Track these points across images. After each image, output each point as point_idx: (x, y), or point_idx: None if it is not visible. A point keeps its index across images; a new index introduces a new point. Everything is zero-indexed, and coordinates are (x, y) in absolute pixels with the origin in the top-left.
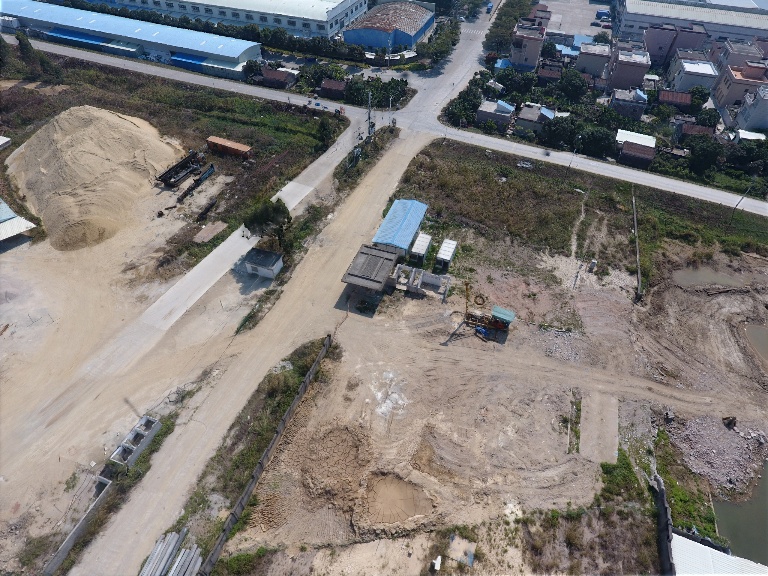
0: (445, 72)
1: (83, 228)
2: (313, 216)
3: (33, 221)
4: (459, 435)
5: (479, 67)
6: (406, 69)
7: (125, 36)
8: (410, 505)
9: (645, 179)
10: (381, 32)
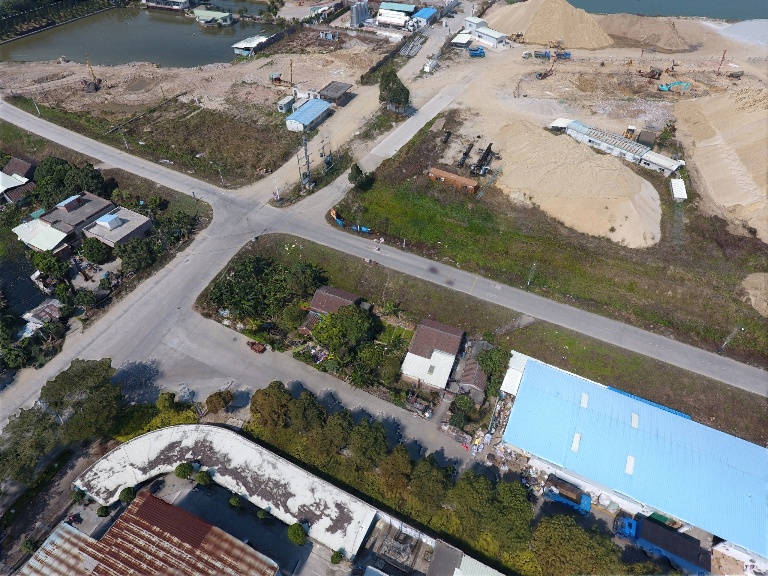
0: None
1: None
2: None
3: None
4: None
5: None
6: None
7: None
8: None
9: (74, 139)
10: None
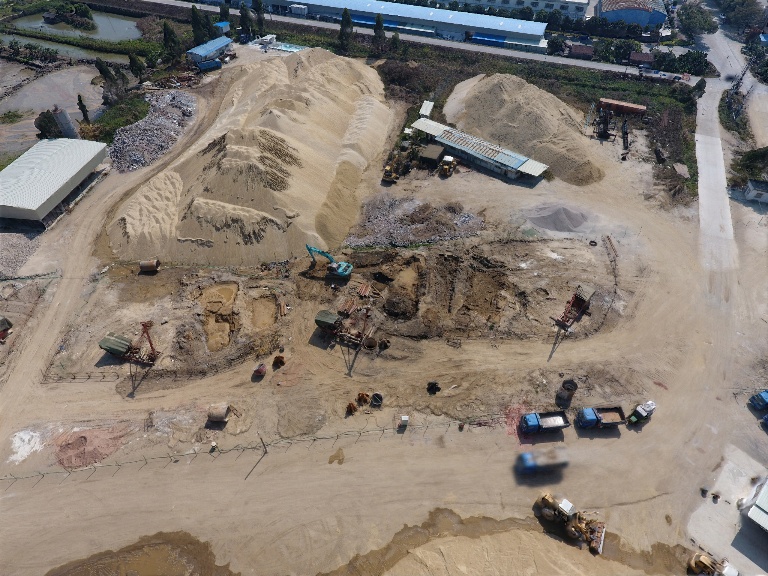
0: (710, 46)
1: (589, 167)
2: None
3: None
4: None
5: (734, 42)
6: (675, 44)
7: (423, 19)
8: None
9: None
10: (643, 12)
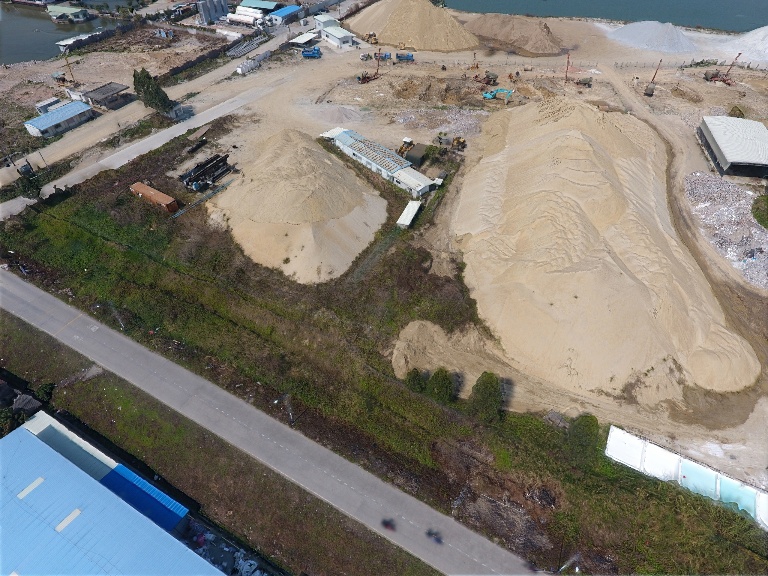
0: None
1: None
2: (118, 136)
3: None
4: (124, 64)
5: None
6: None
7: None
8: (156, 55)
9: None
10: None
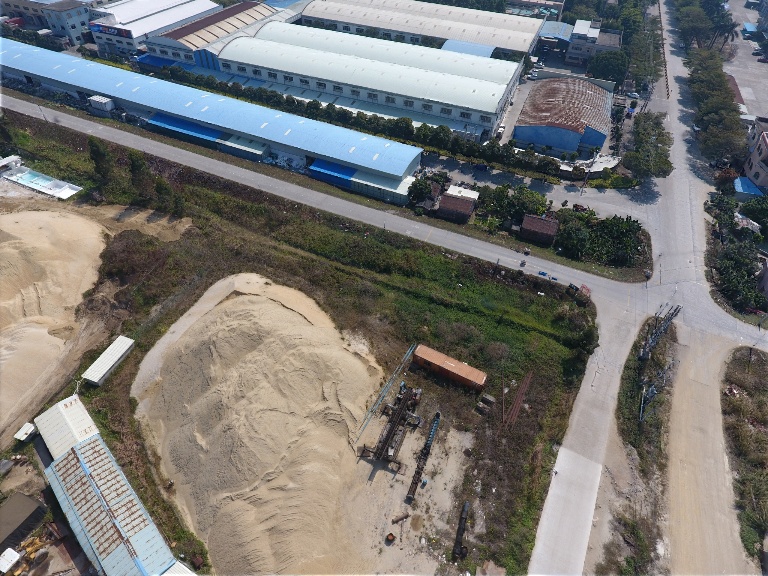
0: (662, 192)
1: None
2: (639, 554)
3: (196, 558)
4: None
5: (700, 182)
6: (609, 187)
7: (249, 134)
8: None
9: None
10: (570, 132)
